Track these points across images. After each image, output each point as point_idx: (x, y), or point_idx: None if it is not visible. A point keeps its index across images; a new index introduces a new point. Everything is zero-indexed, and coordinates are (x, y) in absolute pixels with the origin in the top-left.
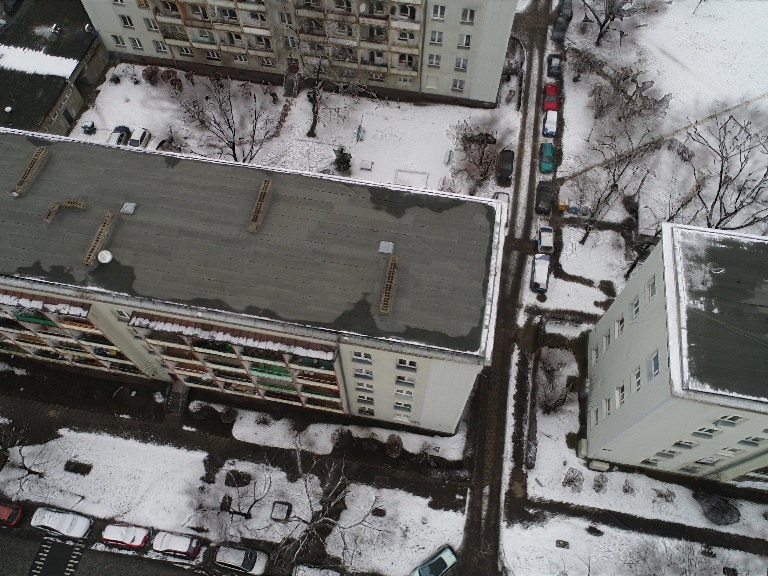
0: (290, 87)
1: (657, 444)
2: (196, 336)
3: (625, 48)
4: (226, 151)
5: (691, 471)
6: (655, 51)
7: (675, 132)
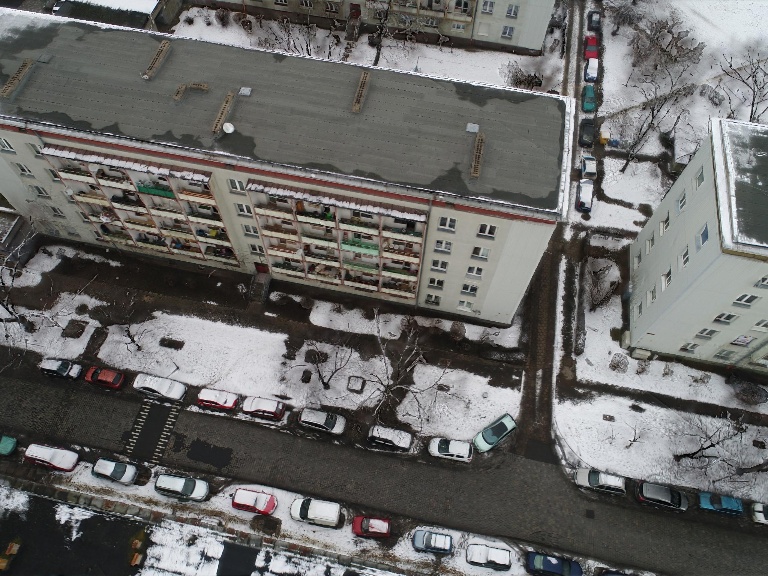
0: (351, 31)
1: (699, 321)
2: (305, 199)
3: (659, 8)
4: None
5: (724, 358)
6: (687, 11)
7: (706, 81)
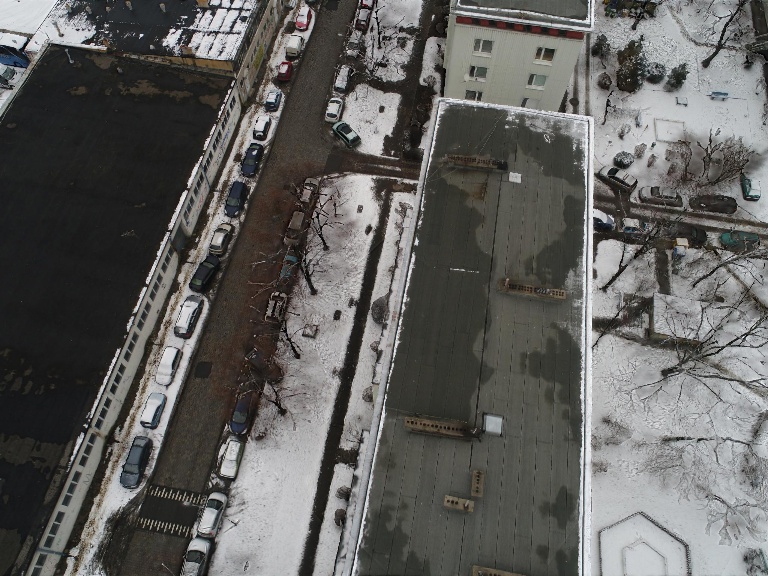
0: None
1: None
2: None
3: None
4: (668, 16)
5: None
6: None
7: None
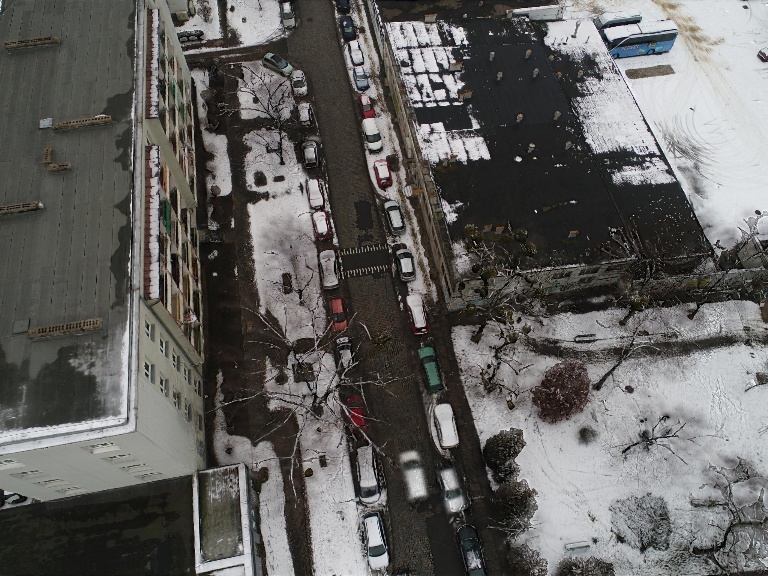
0: None
1: None
2: (158, 77)
3: None
4: None
5: None
6: None
7: None
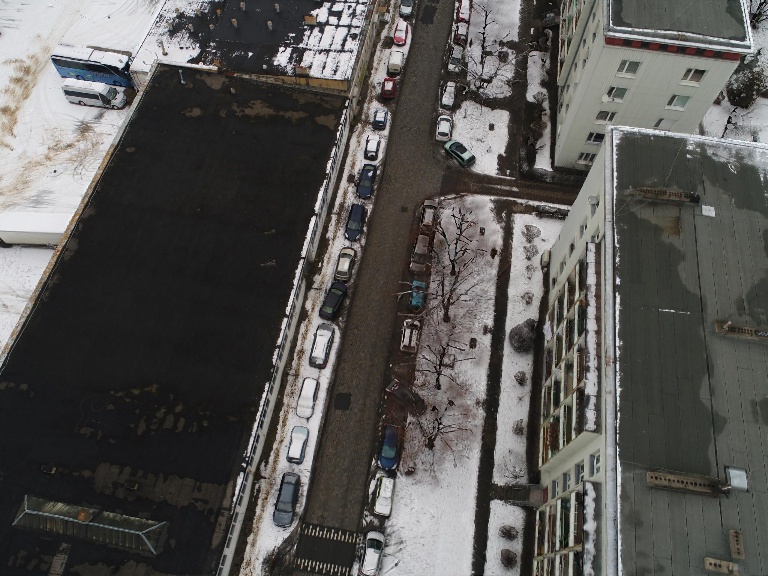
0: None
1: None
2: None
3: None
4: None
5: None
6: None
7: None
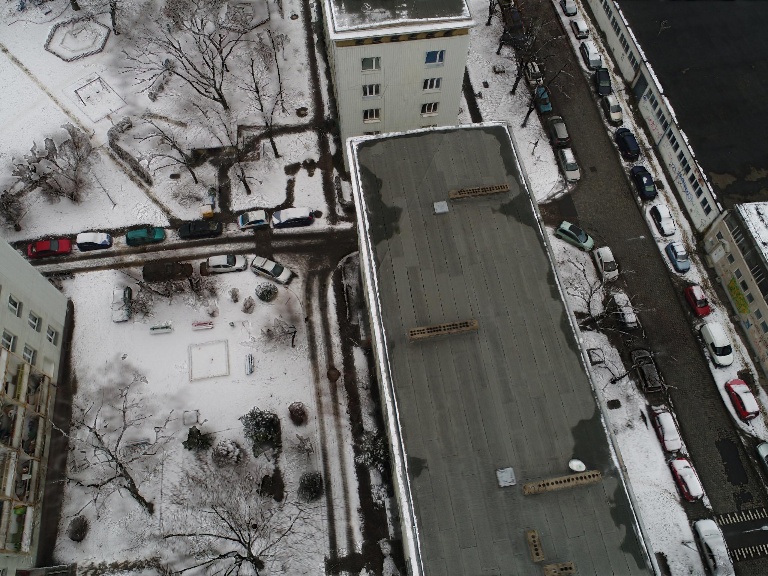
0: None
1: None
2: None
3: None
4: None
5: None
6: None
7: (92, 137)
